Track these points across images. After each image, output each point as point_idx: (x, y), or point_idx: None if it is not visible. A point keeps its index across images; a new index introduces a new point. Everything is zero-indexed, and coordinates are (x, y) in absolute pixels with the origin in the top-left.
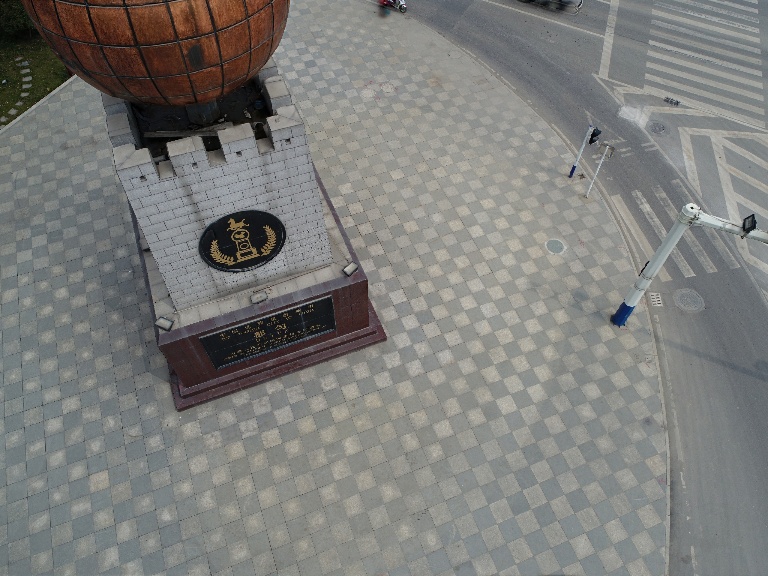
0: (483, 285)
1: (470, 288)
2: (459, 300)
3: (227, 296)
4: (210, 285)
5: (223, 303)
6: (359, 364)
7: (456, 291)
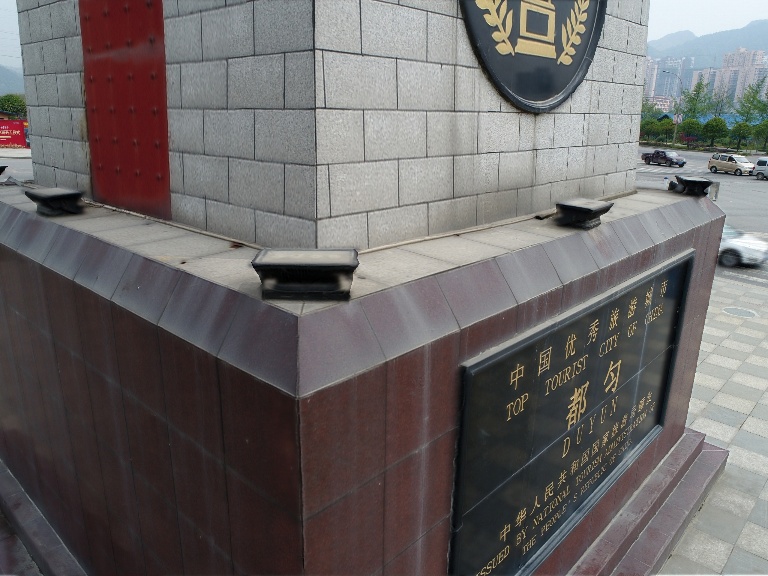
0: (732, 359)
1: (722, 366)
2: (733, 381)
3: (470, 227)
4: (440, 136)
5: (479, 236)
6: (744, 532)
7: (710, 373)
